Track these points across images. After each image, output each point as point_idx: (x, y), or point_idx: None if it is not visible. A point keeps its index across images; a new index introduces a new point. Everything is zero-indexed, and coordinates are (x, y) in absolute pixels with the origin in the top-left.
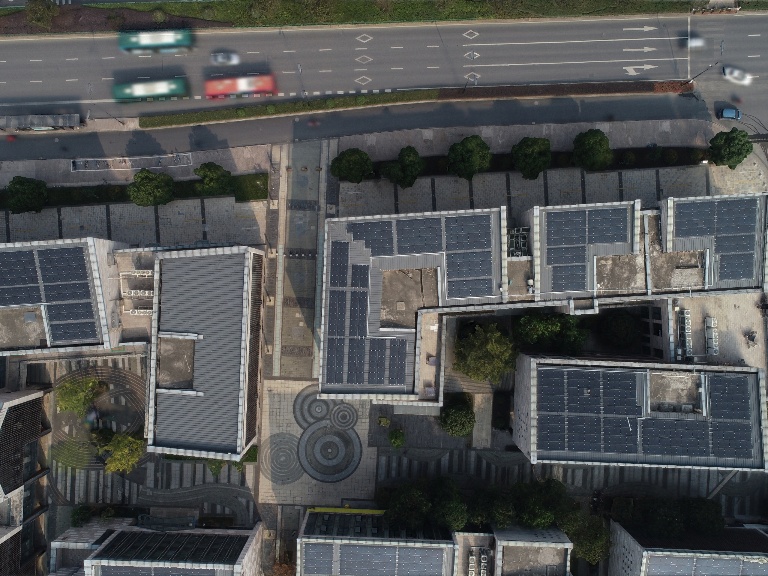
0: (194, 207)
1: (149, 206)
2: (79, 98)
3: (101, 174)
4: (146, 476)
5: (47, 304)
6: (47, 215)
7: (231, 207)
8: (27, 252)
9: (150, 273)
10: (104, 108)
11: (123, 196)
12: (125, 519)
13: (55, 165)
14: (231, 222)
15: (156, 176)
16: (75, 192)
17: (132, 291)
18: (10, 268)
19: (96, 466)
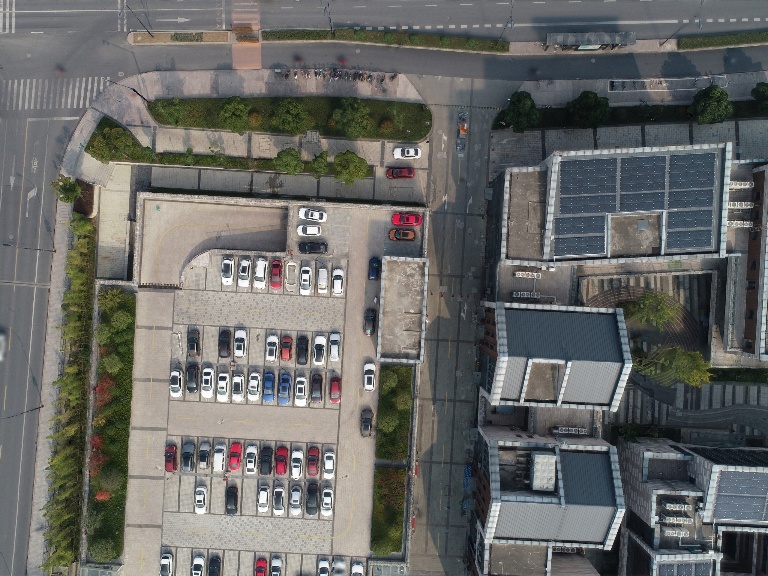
0: (728, 129)
1: (684, 127)
2: (616, 19)
3: (637, 95)
4: (676, 397)
5: (668, 211)
6: (583, 135)
7: (765, 129)
8: (660, 157)
9: (747, 185)
10: (641, 29)
11: (663, 116)
12: (662, 438)
13: (592, 85)
14: (765, 144)
15: (726, 92)
16: (622, 111)
17: (729, 202)
18: (640, 173)
19: (626, 386)
